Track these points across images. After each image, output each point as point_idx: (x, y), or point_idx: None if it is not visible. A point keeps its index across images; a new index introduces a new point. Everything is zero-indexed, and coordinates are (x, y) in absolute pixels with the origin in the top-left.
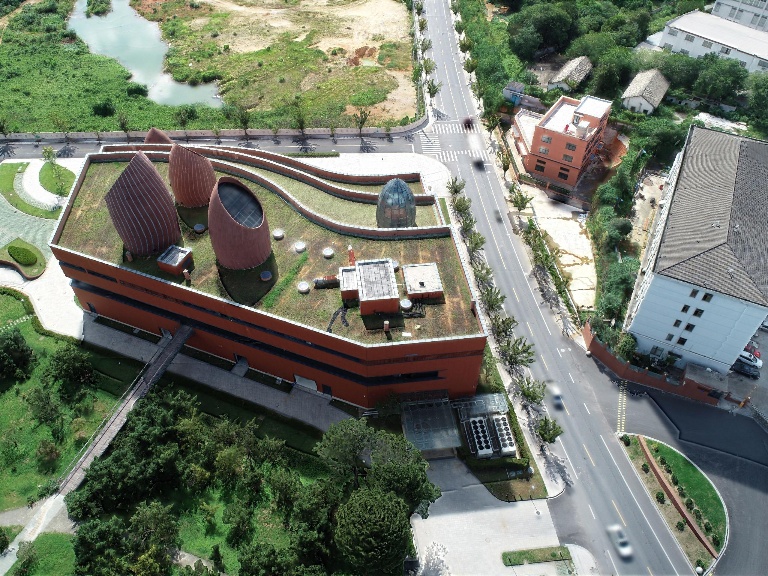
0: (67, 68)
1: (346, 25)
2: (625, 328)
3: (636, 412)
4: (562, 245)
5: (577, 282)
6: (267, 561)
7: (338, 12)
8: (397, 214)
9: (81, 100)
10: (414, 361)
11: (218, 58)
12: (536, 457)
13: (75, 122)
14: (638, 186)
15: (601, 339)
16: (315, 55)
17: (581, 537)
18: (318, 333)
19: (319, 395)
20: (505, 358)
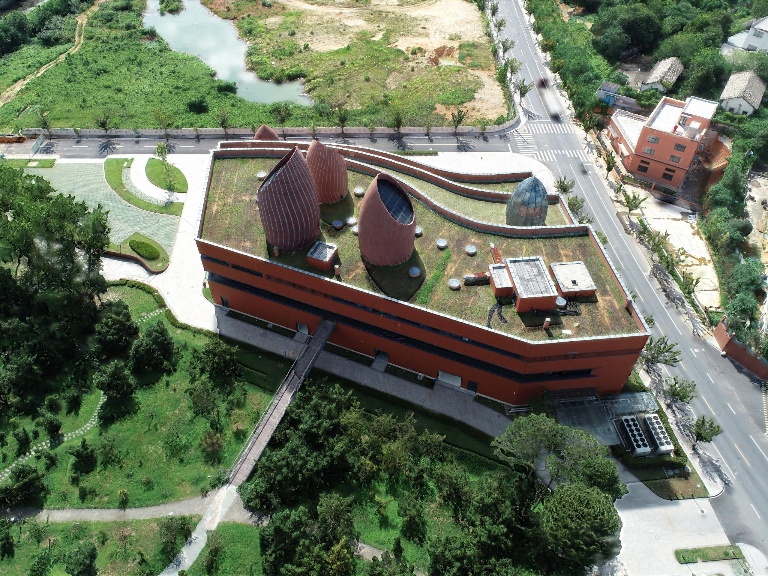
0: (153, 65)
1: (420, 24)
2: (767, 329)
3: None
4: (677, 246)
5: (699, 283)
6: (461, 554)
7: (410, 11)
8: (532, 212)
9: (173, 97)
10: (573, 359)
11: (299, 56)
12: (690, 456)
13: (171, 119)
14: (746, 187)
15: (738, 340)
16: (395, 54)
17: (750, 536)
18: (481, 329)
19: (462, 391)
20: (646, 357)
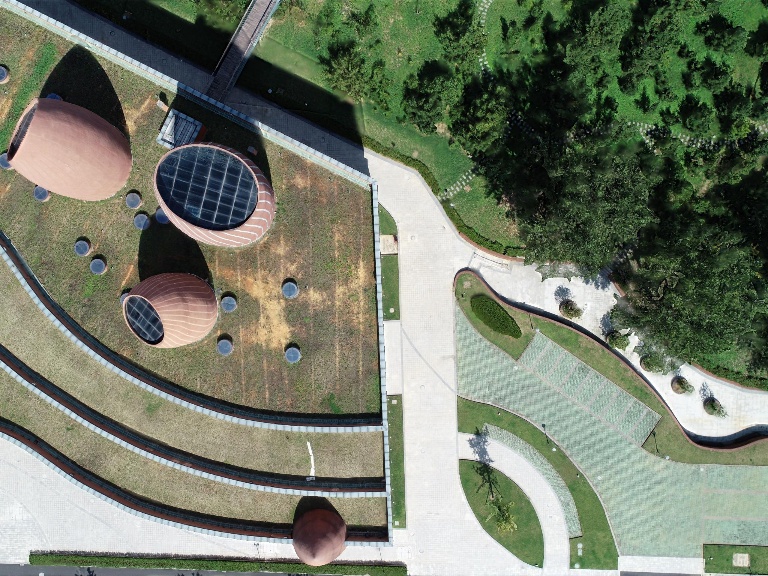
0: None
1: None
2: None
3: None
4: None
5: None
6: None
7: None
8: None
9: None
10: None
11: None
12: None
13: None
14: None
15: None
16: None
17: None
18: None
19: None
20: None
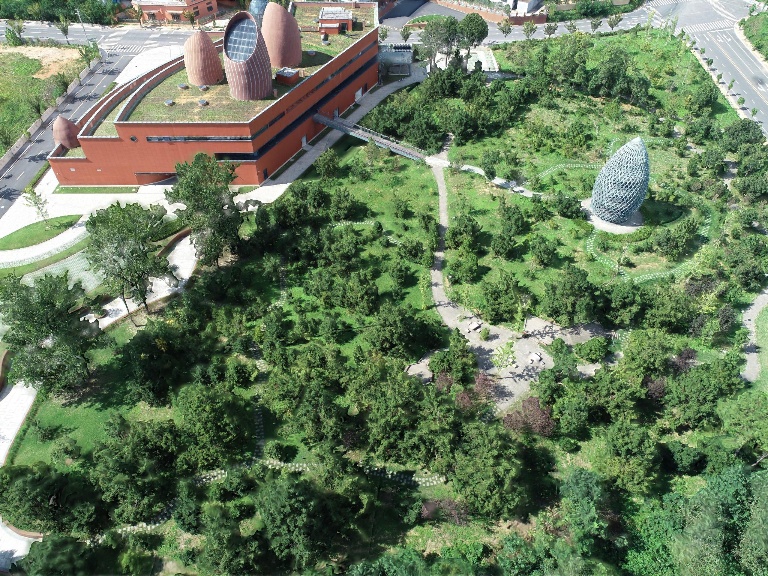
0: None
1: None
2: None
3: (392, 24)
4: None
5: None
6: None
7: None
8: None
9: None
10: None
11: None
12: None
13: None
14: None
15: None
16: None
17: None
18: (365, 37)
19: (365, 96)
20: None
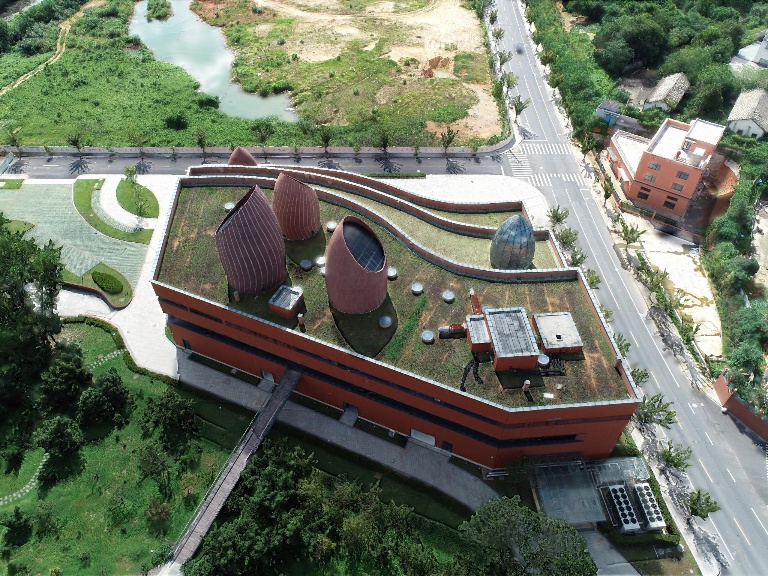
0: (134, 76)
1: (416, 33)
2: None
3: None
4: (677, 283)
5: (699, 326)
6: None
7: (406, 19)
8: (517, 253)
9: (152, 111)
10: (555, 425)
11: (287, 67)
12: (684, 532)
13: (148, 135)
14: (754, 219)
15: (740, 396)
16: (387, 66)
17: None
18: (453, 392)
19: (437, 451)
20: (639, 416)
